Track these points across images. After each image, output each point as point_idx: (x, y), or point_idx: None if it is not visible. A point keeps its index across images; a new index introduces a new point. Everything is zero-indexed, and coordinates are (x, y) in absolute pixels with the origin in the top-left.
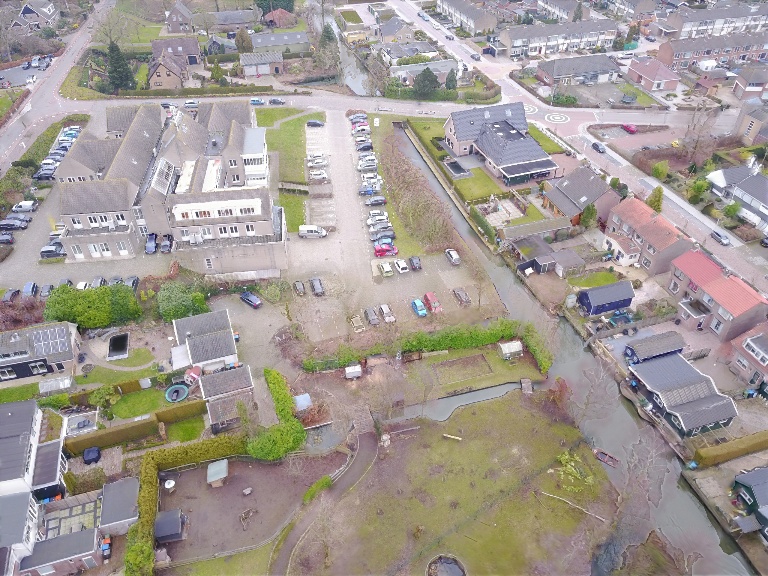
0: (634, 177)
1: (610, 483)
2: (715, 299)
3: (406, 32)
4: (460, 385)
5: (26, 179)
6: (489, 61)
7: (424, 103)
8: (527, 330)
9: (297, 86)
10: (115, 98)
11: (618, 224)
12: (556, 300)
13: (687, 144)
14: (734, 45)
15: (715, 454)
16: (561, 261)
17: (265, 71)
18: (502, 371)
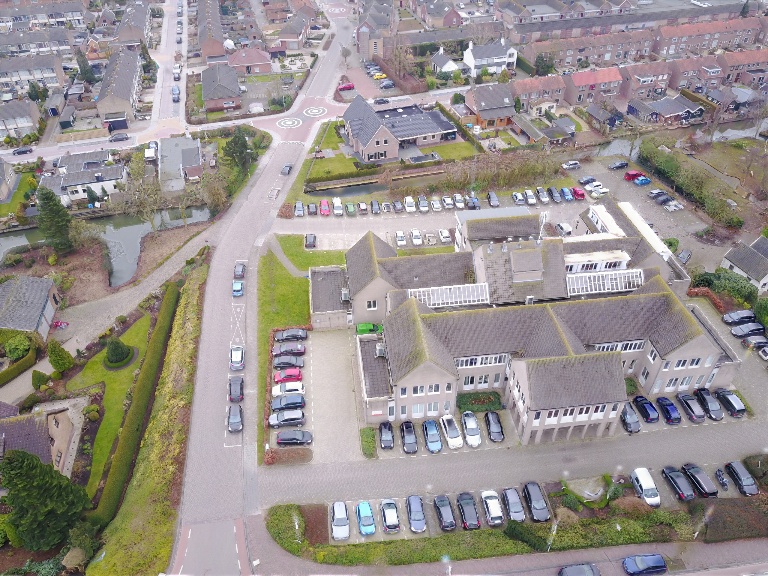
0: (429, 97)
1: (741, 138)
2: (609, 81)
3: (7, 169)
4: (705, 172)
5: (569, 516)
6: (137, 132)
7: (259, 171)
8: (653, 140)
9: (154, 268)
10: (175, 489)
11: (527, 98)
12: (600, 137)
13: (409, 64)
14: (220, 24)
15: (717, 105)
16: (569, 124)
17: (50, 313)
18: (682, 158)
